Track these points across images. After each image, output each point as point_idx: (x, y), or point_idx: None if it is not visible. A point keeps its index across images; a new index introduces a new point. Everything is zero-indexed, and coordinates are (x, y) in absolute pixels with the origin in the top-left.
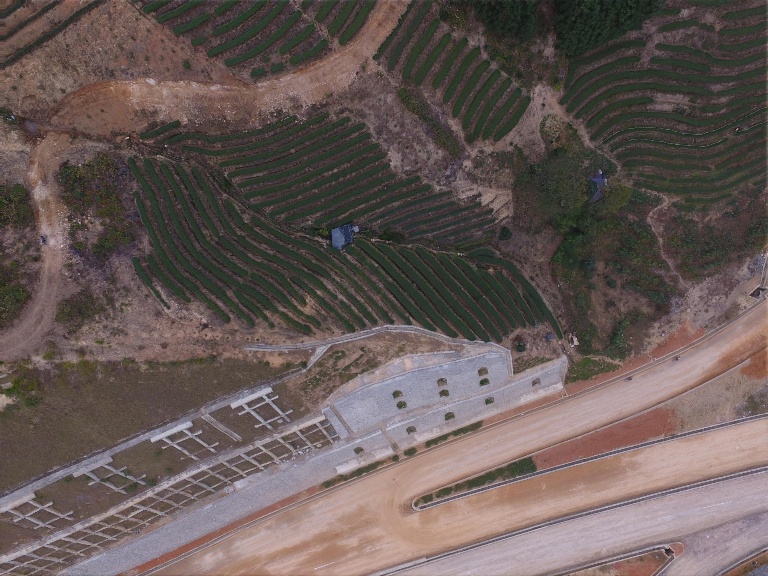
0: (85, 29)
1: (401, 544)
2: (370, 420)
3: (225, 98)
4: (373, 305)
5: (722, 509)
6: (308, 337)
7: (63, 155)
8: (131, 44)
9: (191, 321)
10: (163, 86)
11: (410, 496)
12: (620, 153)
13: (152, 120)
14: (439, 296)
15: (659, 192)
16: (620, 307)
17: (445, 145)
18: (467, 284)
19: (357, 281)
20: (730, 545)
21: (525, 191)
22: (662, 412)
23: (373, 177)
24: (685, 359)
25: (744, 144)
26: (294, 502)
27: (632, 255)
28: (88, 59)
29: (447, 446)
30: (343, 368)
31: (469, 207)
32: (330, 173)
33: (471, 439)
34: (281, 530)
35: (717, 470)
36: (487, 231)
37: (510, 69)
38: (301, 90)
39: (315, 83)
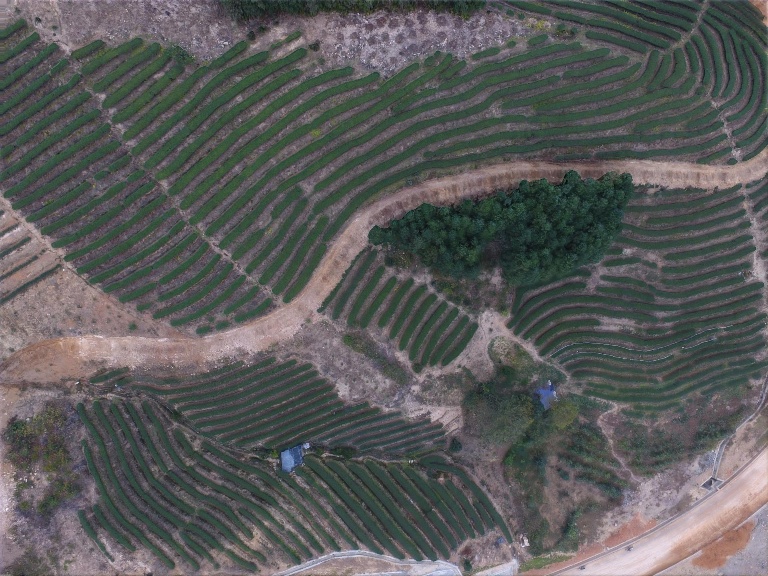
0: (33, 298)
1: None
2: None
3: (172, 349)
4: (320, 532)
5: None
6: (253, 575)
7: (12, 409)
8: (78, 310)
9: (135, 571)
10: (111, 339)
11: None
12: (569, 364)
13: (101, 367)
14: (387, 514)
15: (608, 400)
16: (573, 497)
17: (392, 376)
18: (416, 497)
19: (305, 506)
20: None
21: (475, 404)
22: None
23: (321, 405)
24: (638, 548)
25: (690, 359)
26: None
27: (583, 455)
28: (36, 322)
29: None
30: None
31: (418, 424)
32: (279, 404)
33: None
34: None
35: None
36: (437, 441)
37: (457, 300)
38: (247, 342)
39: (260, 335)
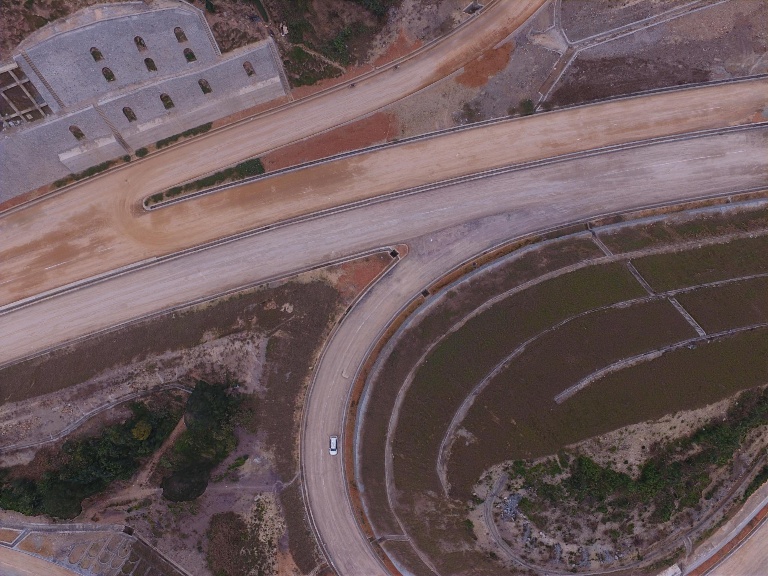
0: None
1: (133, 244)
2: (79, 91)
3: None
4: None
5: (445, 214)
6: None
7: None
8: None
9: None
10: None
11: (142, 196)
12: None
13: None
14: None
15: None
16: (343, 19)
17: None
18: None
19: None
20: (453, 248)
21: None
22: (383, 117)
23: None
24: (405, 69)
25: None
26: (25, 201)
27: None
28: None
29: (178, 148)
30: (25, 4)
31: None
32: None
33: (202, 142)
34: (12, 230)
35: (439, 176)
36: None
37: None
38: None
39: None
